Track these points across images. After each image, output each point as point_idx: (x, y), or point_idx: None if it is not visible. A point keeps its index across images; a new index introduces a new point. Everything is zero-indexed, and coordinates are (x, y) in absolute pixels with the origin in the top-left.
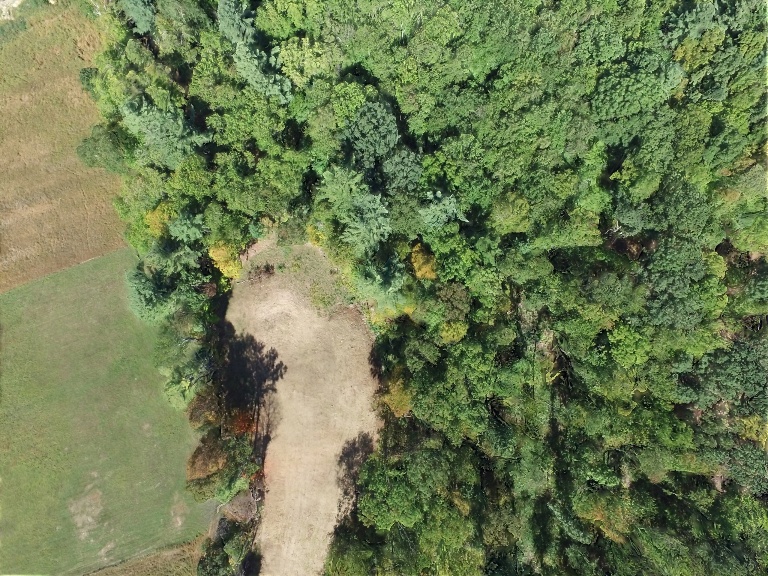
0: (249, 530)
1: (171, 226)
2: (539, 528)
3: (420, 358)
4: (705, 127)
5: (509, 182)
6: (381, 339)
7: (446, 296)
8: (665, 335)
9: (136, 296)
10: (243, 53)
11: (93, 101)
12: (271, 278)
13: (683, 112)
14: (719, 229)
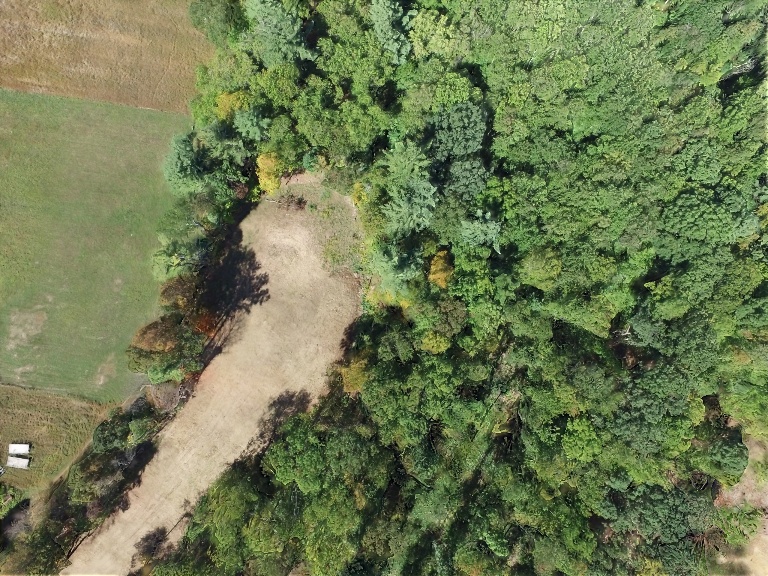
0: (160, 420)
1: (238, 115)
2: (414, 559)
3: (393, 350)
4: (752, 285)
5: (554, 240)
6: (366, 318)
7: (446, 308)
8: (618, 447)
9: (174, 159)
10: None
11: None
12: (299, 211)
13: (740, 262)
14: (715, 382)
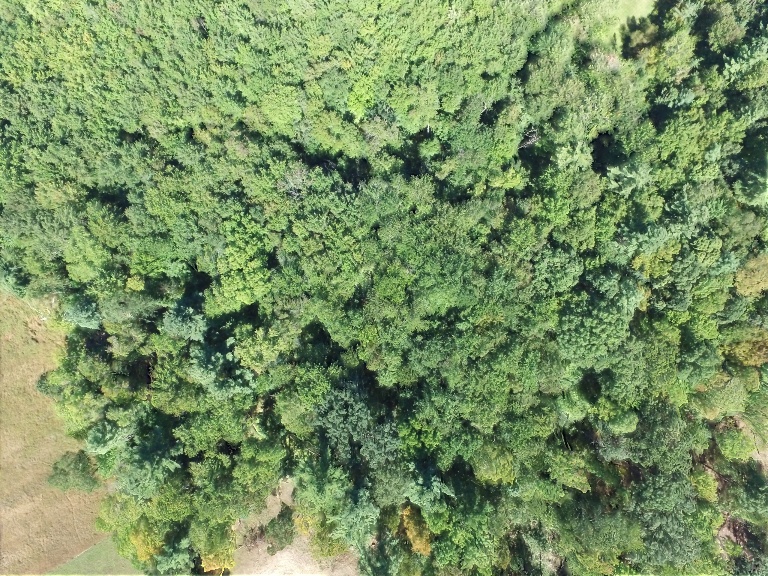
0: None
1: (158, 567)
2: None
3: None
4: (675, 348)
5: (488, 432)
6: None
7: None
8: (666, 573)
9: None
10: (198, 374)
11: None
12: None
13: (650, 339)
14: (704, 434)
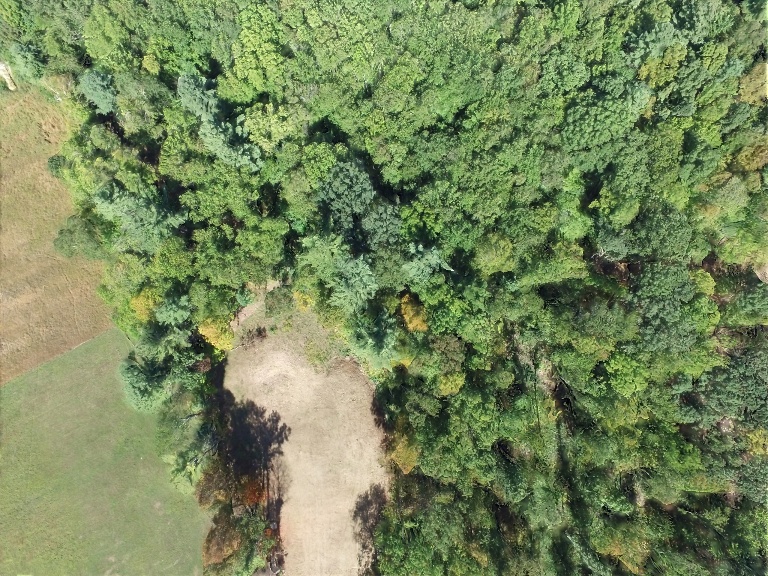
0: None
1: (157, 313)
2: (560, 557)
3: (421, 412)
4: (678, 146)
5: (489, 223)
6: (381, 387)
7: (440, 349)
8: (662, 360)
9: (130, 390)
10: (208, 130)
11: (64, 187)
12: (264, 341)
13: (654, 134)
14: (703, 243)
